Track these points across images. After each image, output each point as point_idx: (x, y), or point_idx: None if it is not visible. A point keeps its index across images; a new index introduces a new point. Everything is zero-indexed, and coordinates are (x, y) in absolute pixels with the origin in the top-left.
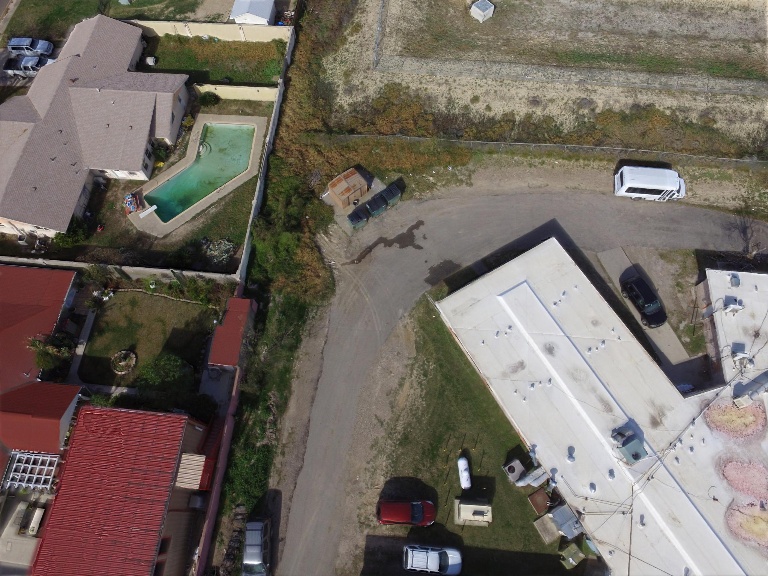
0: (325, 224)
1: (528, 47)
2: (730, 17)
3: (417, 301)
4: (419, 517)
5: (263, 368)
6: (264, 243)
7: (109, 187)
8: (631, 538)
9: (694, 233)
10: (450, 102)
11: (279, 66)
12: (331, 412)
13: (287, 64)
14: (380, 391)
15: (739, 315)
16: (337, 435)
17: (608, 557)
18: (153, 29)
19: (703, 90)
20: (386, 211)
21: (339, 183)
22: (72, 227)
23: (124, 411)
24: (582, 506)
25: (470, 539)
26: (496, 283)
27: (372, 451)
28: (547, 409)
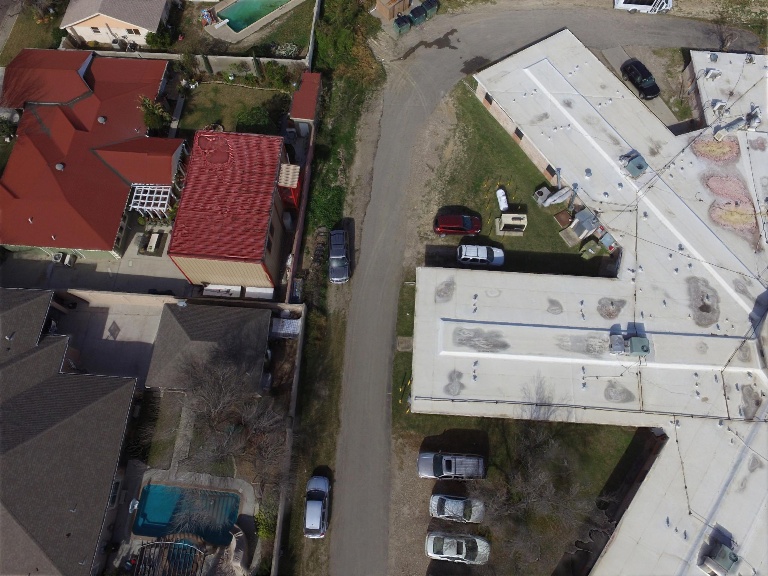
0: (374, 32)
1: None
2: None
3: (455, 85)
4: (468, 226)
5: (332, 132)
6: (326, 39)
7: (185, 7)
8: (637, 226)
9: (680, 36)
10: None
11: None
12: (390, 163)
13: None
14: (430, 147)
15: (717, 80)
16: (397, 178)
17: (620, 239)
18: None
19: None
20: (425, 22)
21: None
22: (160, 29)
23: (232, 133)
24: (598, 207)
25: (509, 245)
26: (522, 60)
27: (426, 188)
28: (568, 144)
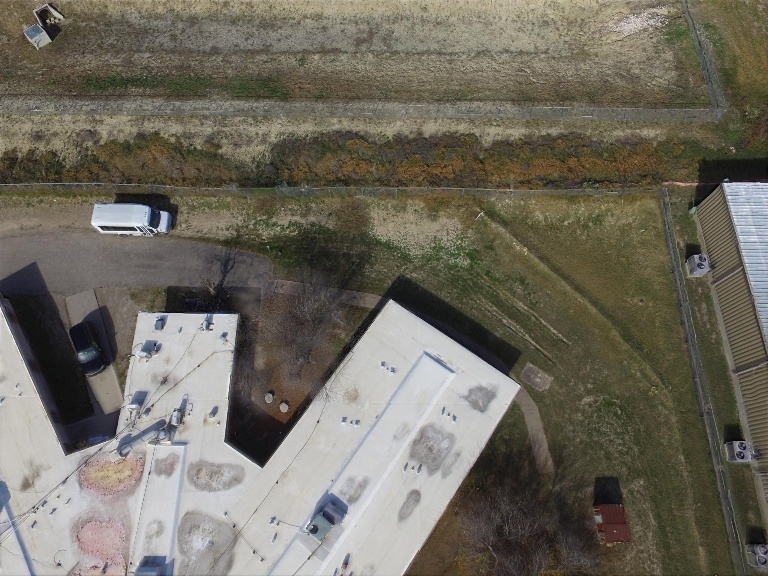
0: None
1: (67, 75)
2: (301, 27)
3: None
4: None
5: None
6: None
7: None
8: None
9: (173, 269)
10: None
11: None
12: None
13: None
14: None
15: (153, 361)
16: None
17: None
18: None
19: (214, 113)
20: None
21: None
22: None
23: None
24: None
25: None
26: None
27: None
28: None
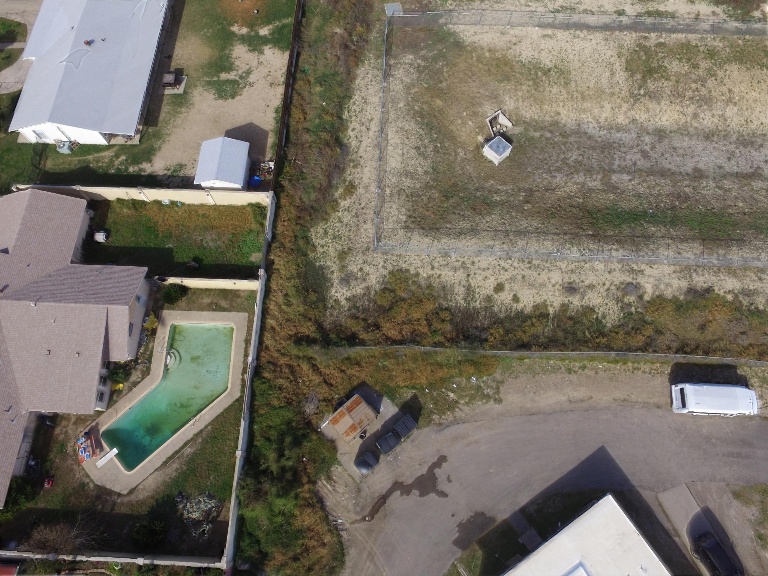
0: (327, 466)
1: (556, 203)
2: None
3: (445, 574)
4: None
5: None
6: (254, 511)
7: (56, 422)
8: None
9: None
10: (469, 292)
11: (258, 240)
12: None
13: (268, 241)
14: None
15: None
16: None
17: None
18: (100, 194)
19: None
20: (400, 445)
21: (342, 418)
22: (11, 498)
23: None
24: None
25: None
26: (544, 567)
27: None
28: None
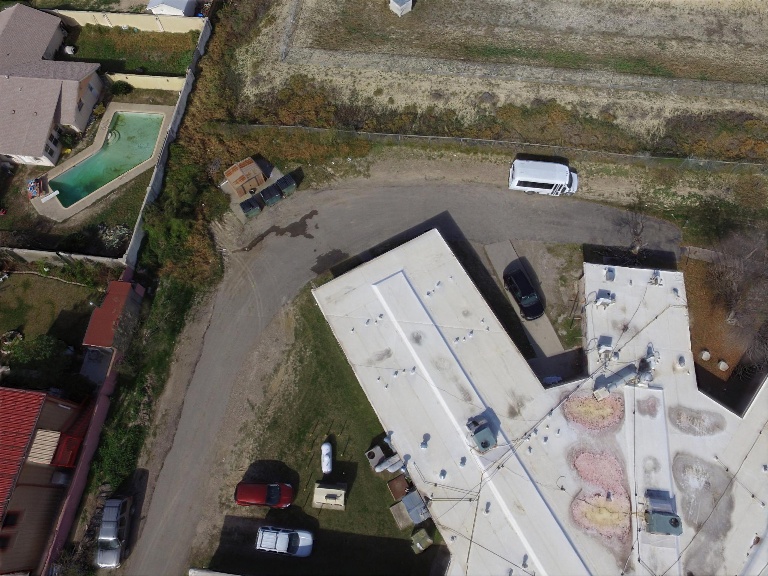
0: (221, 212)
1: (441, 41)
2: (650, 14)
3: (301, 289)
4: (275, 499)
5: (143, 351)
6: (154, 229)
7: (16, 172)
8: (474, 524)
9: (584, 228)
10: (354, 94)
11: (193, 57)
12: (205, 395)
13: (200, 55)
14: (255, 376)
15: (610, 309)
16: (208, 418)
17: (450, 542)
18: (74, 19)
19: (606, 86)
20: (281, 200)
21: (234, 172)
22: None
23: None
24: (431, 492)
25: (326, 522)
26: (373, 272)
27: (240, 434)
28: (408, 396)
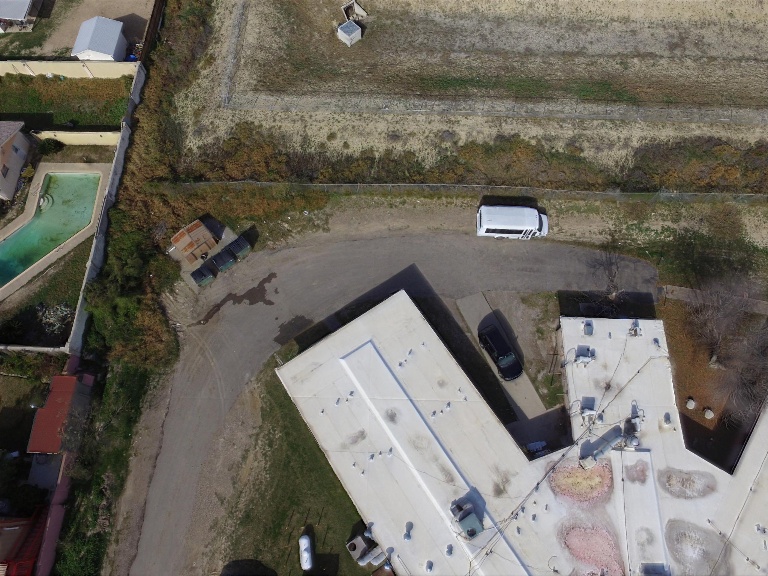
0: (171, 282)
1: (395, 73)
2: (610, 30)
3: (265, 363)
4: None
5: (97, 448)
6: (98, 310)
7: None
8: None
9: (557, 273)
10: (306, 140)
11: (128, 105)
12: (169, 493)
13: (135, 104)
14: (221, 466)
15: (591, 366)
16: (174, 518)
17: None
18: None
19: (570, 116)
20: (236, 264)
21: (182, 238)
22: None
23: None
24: None
25: None
26: (340, 344)
27: (210, 533)
28: (386, 482)
